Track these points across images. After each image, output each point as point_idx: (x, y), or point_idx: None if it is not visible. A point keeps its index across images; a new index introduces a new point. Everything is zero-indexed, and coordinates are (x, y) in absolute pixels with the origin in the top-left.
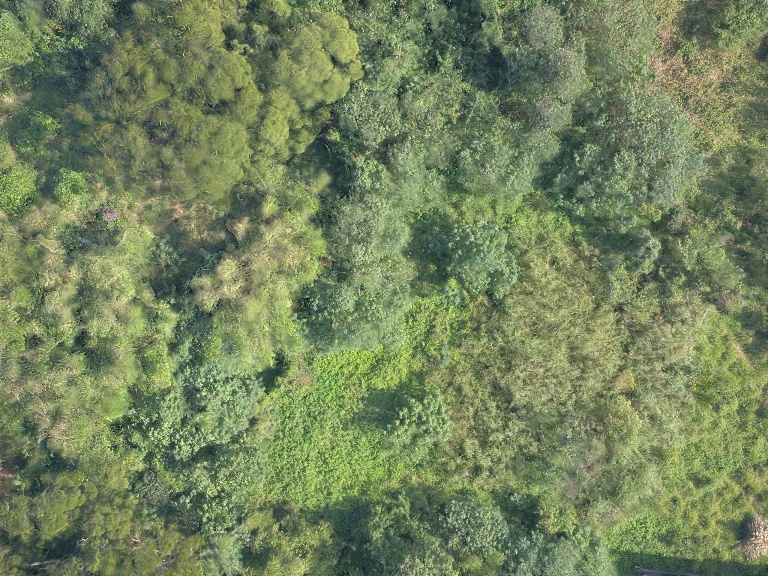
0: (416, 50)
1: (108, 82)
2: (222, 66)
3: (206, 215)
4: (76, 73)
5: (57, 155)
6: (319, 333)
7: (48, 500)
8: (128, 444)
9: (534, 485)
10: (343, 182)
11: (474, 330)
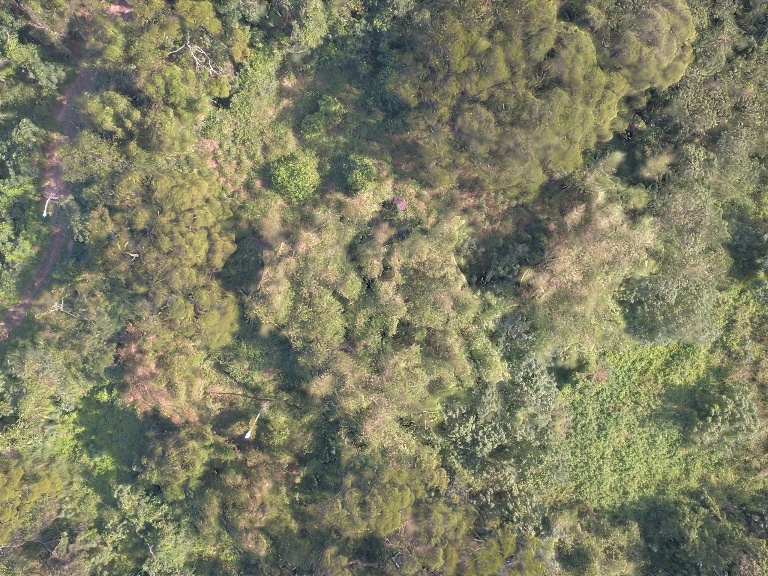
0: (741, 34)
1: (444, 64)
2: (575, 47)
3: (498, 204)
4: (367, 57)
5: (342, 141)
6: (630, 327)
7: (384, 498)
8: (417, 441)
9: None
10: (644, 171)
11: None
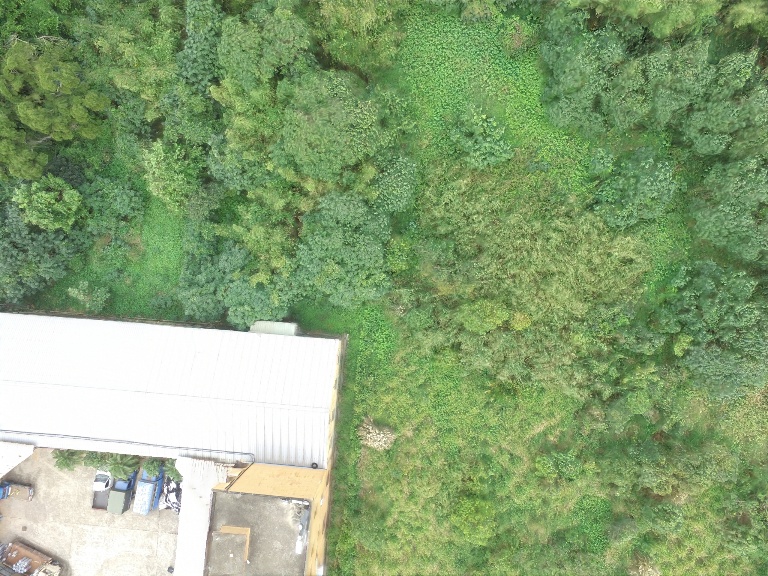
0: None
1: None
2: None
3: None
4: None
5: None
6: (568, 42)
7: None
8: None
9: (422, 244)
10: None
11: None
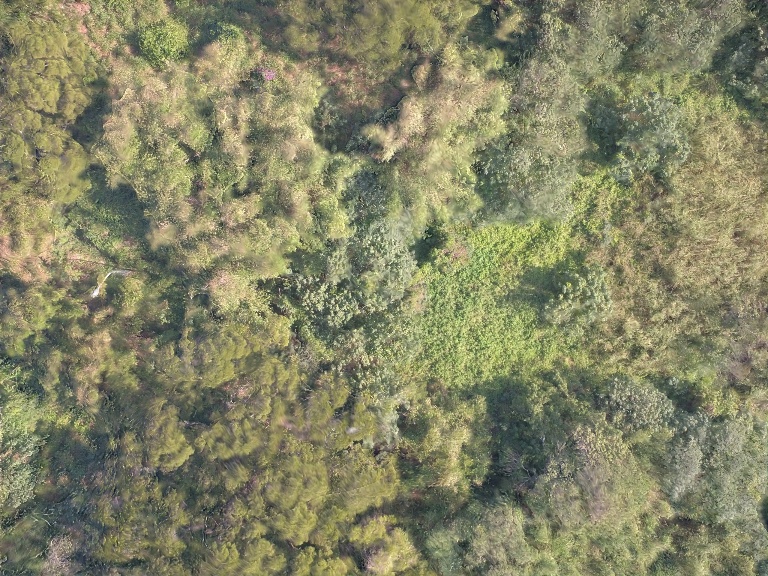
0: None
1: None
2: None
3: (365, 79)
4: None
5: (212, 10)
6: (485, 200)
7: (216, 346)
8: (274, 312)
9: (692, 371)
10: (511, 51)
11: (636, 211)
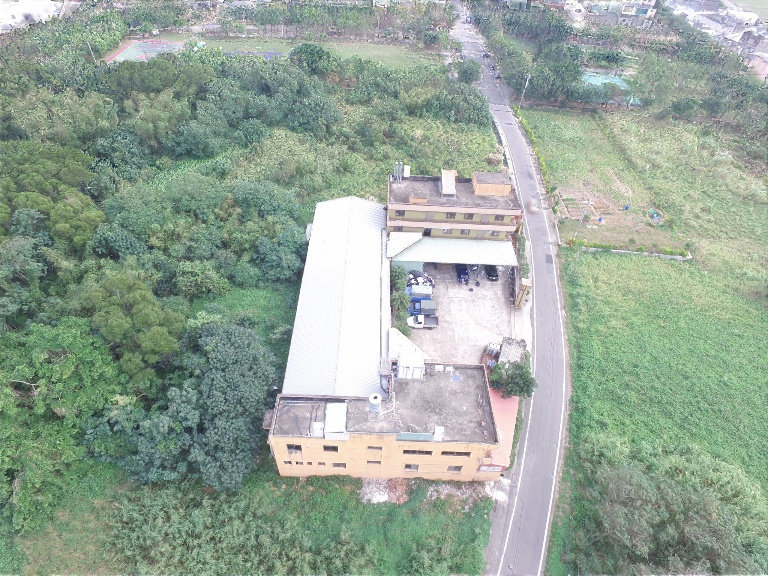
0: (239, 84)
1: None
2: None
3: None
4: (109, 95)
5: None
6: None
7: None
8: None
9: None
10: None
11: None
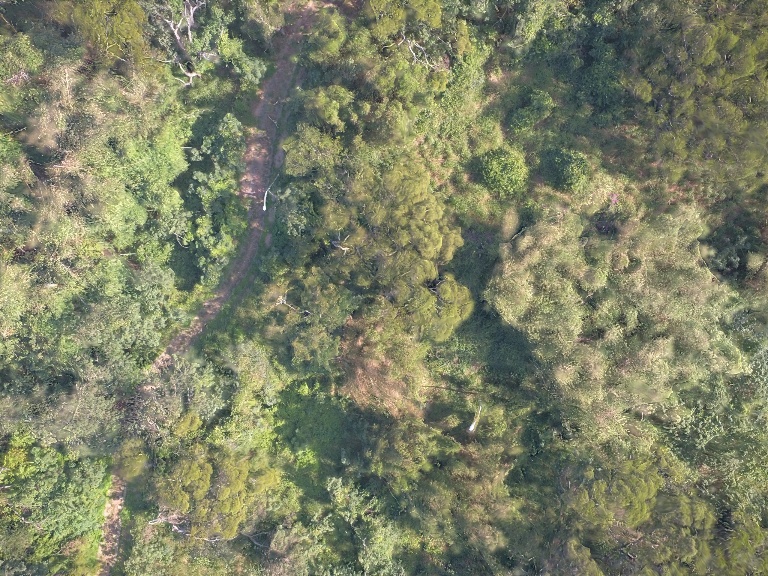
0: None
1: (687, 57)
2: None
3: (707, 198)
4: (579, 51)
5: (551, 136)
6: None
7: (632, 489)
8: (628, 433)
9: None
10: None
11: None
